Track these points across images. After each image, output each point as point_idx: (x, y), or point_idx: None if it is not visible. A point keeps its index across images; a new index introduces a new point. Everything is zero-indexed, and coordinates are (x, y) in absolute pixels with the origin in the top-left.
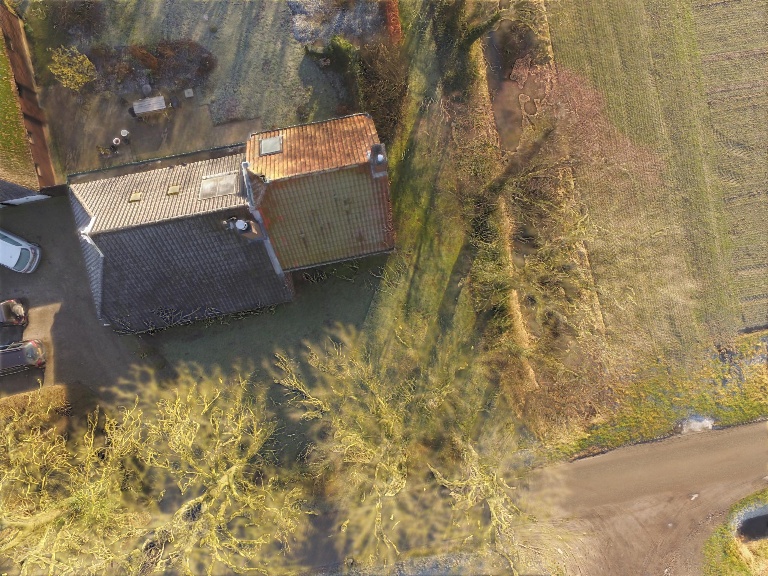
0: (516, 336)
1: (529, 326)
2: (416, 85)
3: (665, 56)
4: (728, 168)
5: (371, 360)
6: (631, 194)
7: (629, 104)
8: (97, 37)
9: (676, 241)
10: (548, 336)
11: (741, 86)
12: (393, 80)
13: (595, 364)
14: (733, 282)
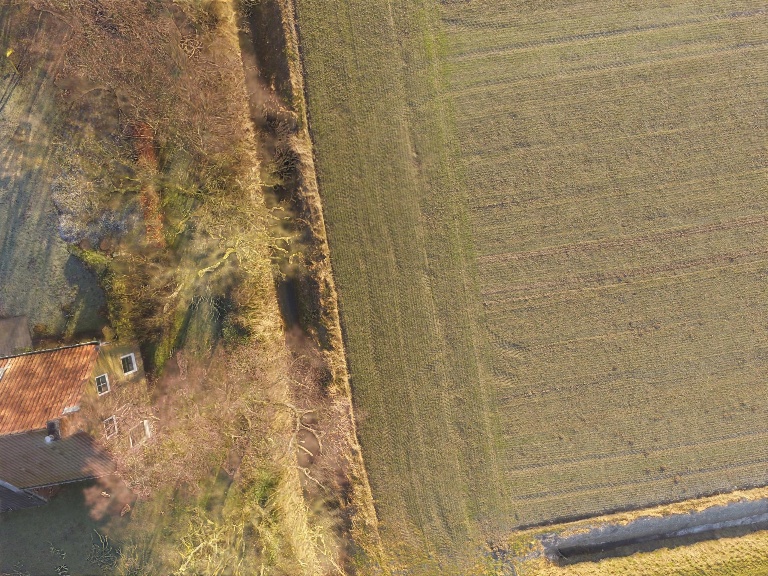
0: (285, 531)
1: (312, 510)
2: (185, 284)
3: (440, 257)
4: (503, 369)
5: (138, 553)
6: (404, 393)
7: (403, 304)
8: None
9: (449, 440)
10: (329, 521)
11: (518, 288)
12: (155, 284)
13: (367, 558)
14: (506, 481)
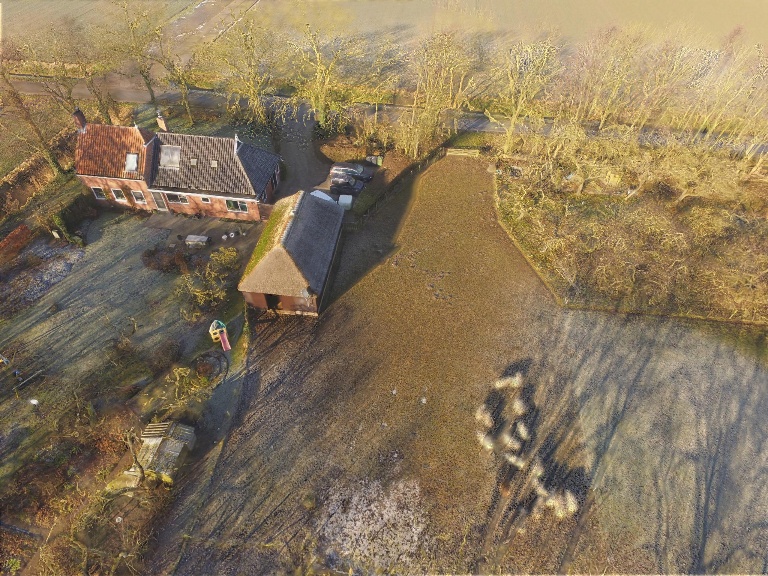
0: None
1: None
2: None
3: None
4: None
5: None
6: None
7: None
8: (205, 288)
9: None
10: None
11: None
12: None
13: None
14: None
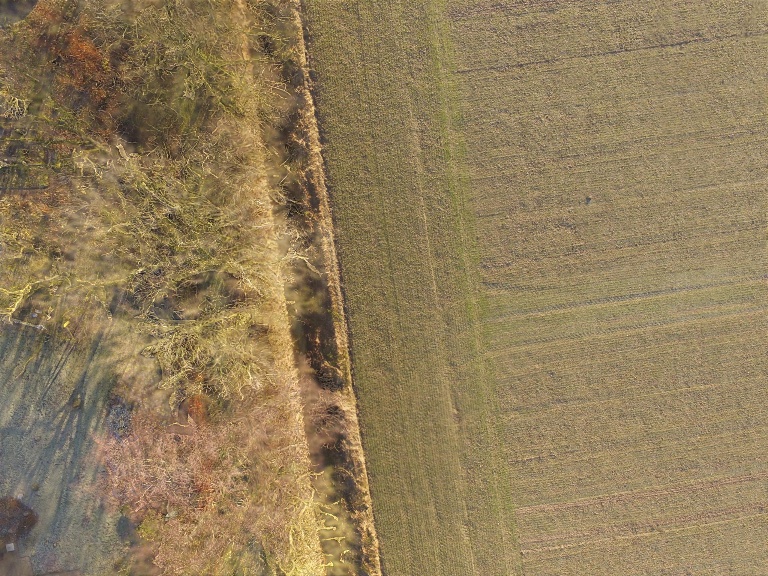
0: None
1: None
2: None
3: (479, 509)
4: None
5: None
6: None
7: (443, 554)
8: None
9: None
10: None
11: (554, 537)
12: None
13: None
14: None
